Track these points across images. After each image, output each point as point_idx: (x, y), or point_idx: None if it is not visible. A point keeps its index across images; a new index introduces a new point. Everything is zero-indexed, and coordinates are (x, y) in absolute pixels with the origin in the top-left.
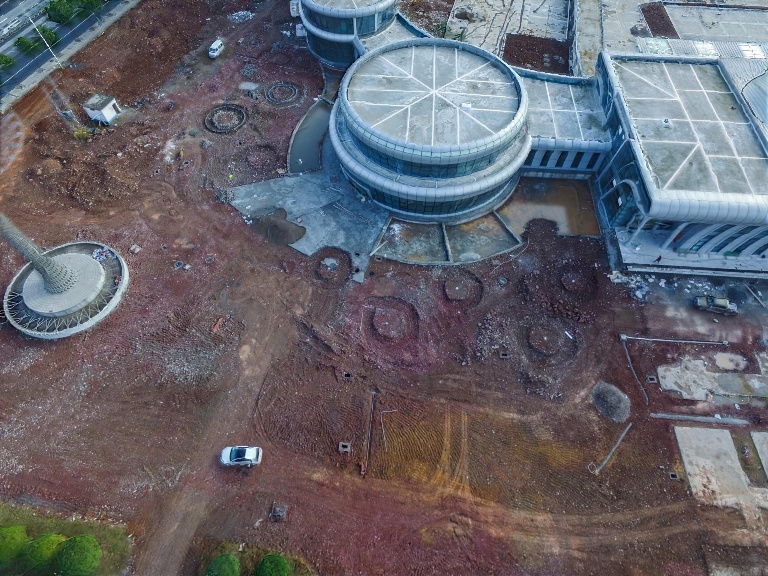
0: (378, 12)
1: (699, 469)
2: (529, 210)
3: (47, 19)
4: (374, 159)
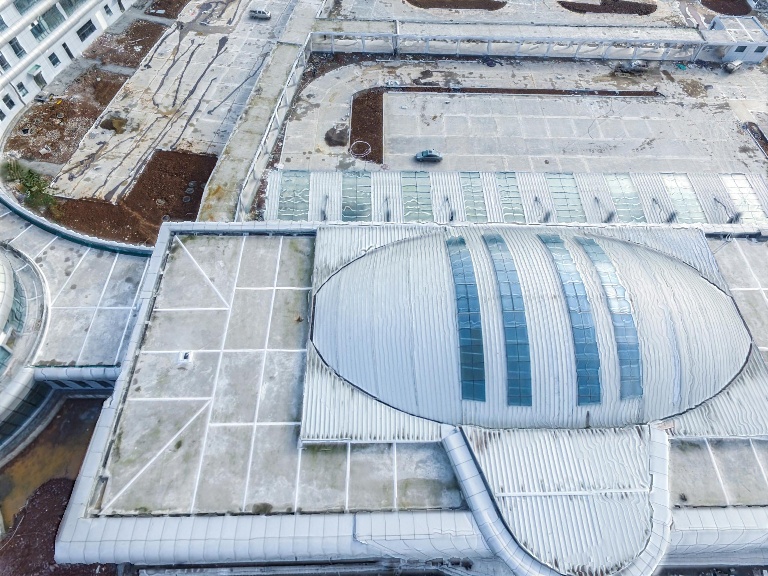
0: None
1: None
2: (52, 463)
3: None
4: None
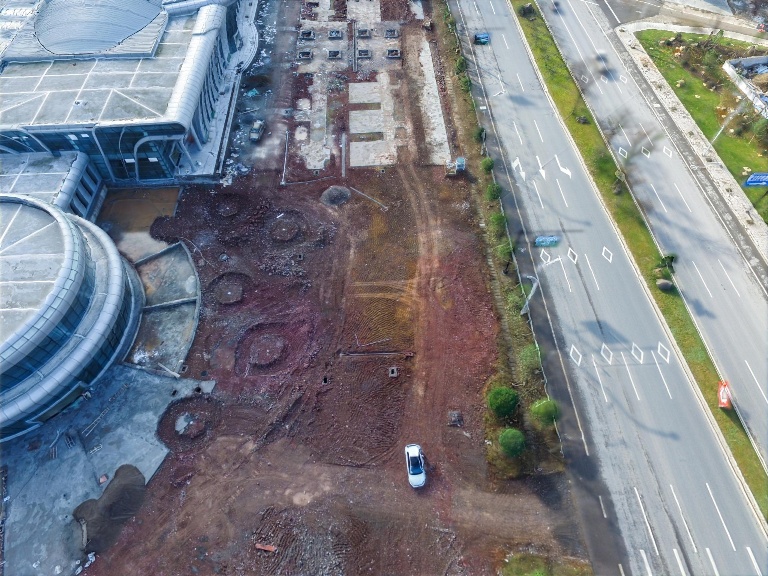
0: None
1: (377, 159)
2: (137, 237)
3: None
4: (39, 363)
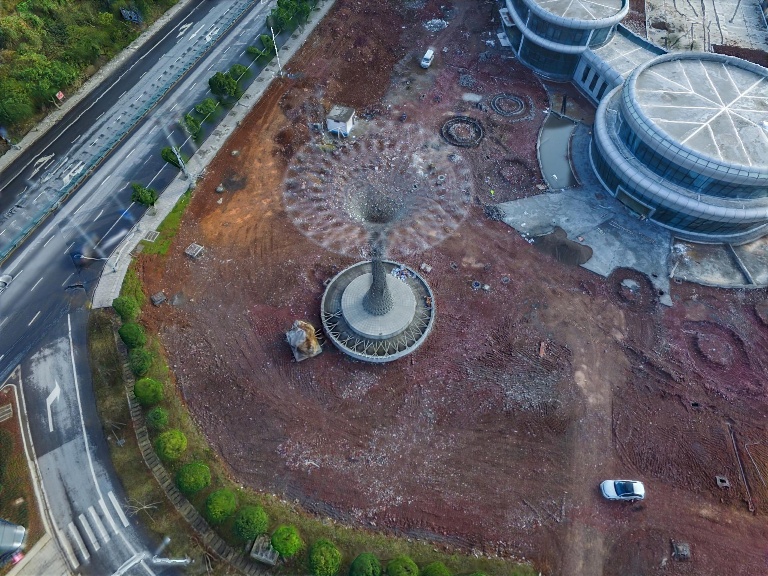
0: (615, 23)
1: None
2: None
3: (245, 26)
4: (672, 178)
